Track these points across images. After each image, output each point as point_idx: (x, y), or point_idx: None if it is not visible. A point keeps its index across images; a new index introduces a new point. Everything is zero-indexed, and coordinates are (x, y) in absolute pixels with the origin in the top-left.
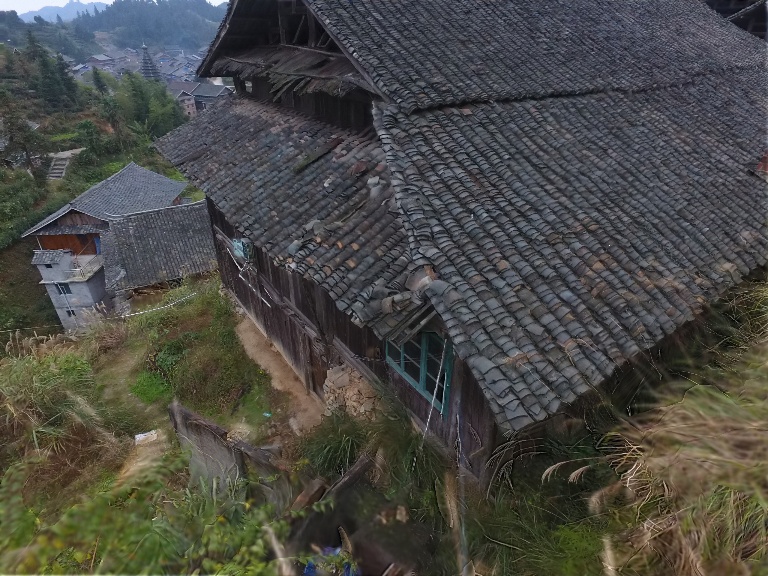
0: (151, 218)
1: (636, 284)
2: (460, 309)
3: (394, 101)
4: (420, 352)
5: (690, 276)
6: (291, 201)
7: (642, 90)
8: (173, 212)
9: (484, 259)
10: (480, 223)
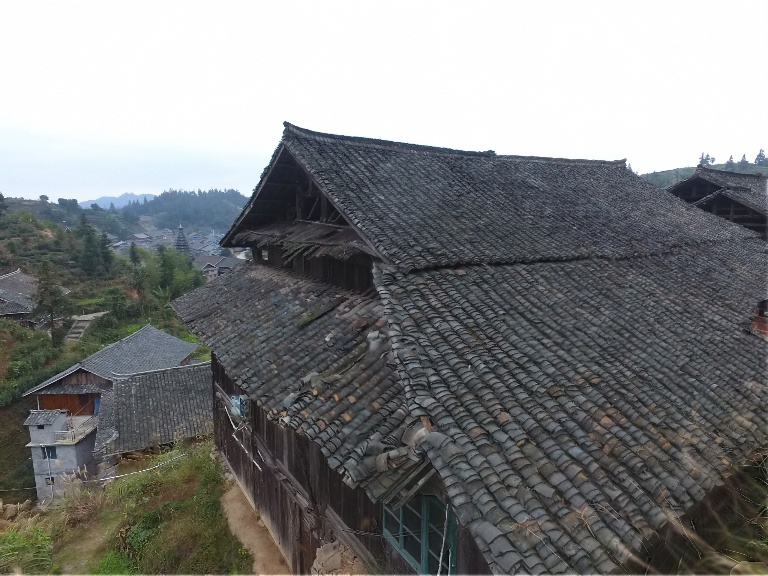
0: (156, 378)
1: (651, 442)
2: (459, 464)
3: (393, 262)
4: (420, 522)
5: (708, 435)
6: (292, 355)
7: (625, 258)
8: (179, 372)
9: (483, 410)
10: (478, 374)
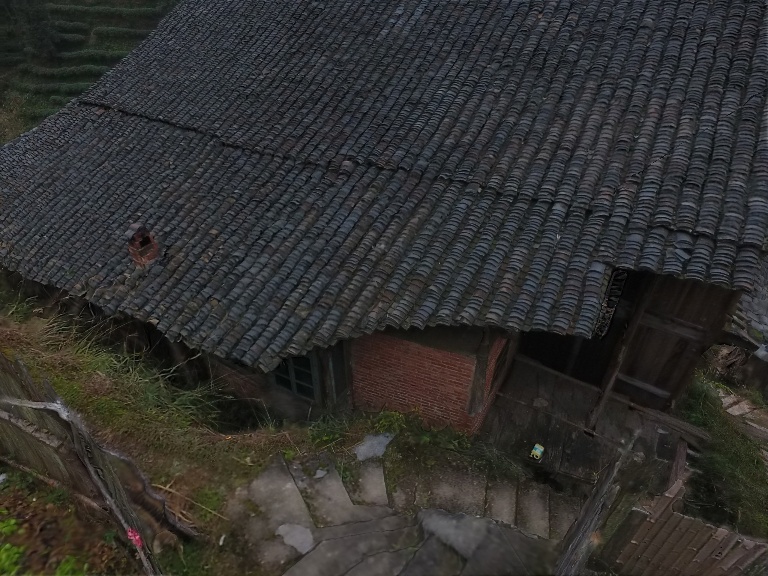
0: None
1: None
2: None
3: None
4: None
5: None
6: None
7: (239, 147)
8: None
9: None
10: None
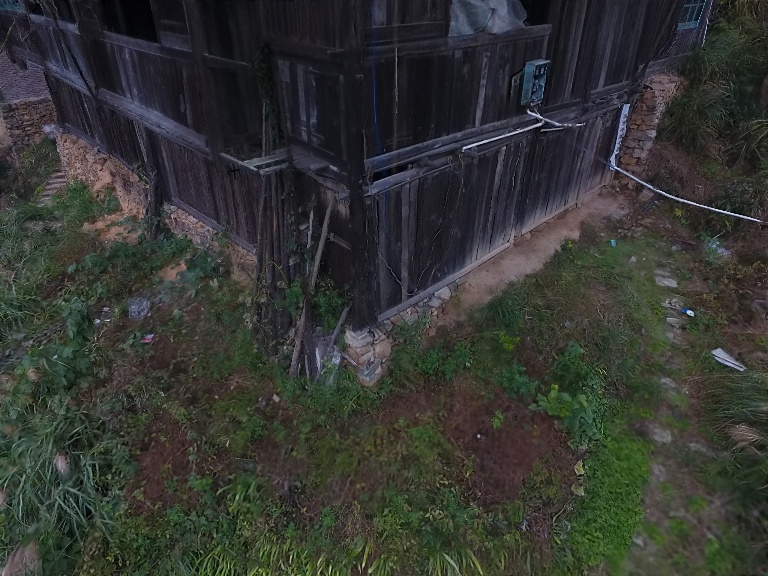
0: None
1: None
2: None
3: None
4: None
5: None
6: None
7: None
8: None
9: None
10: None
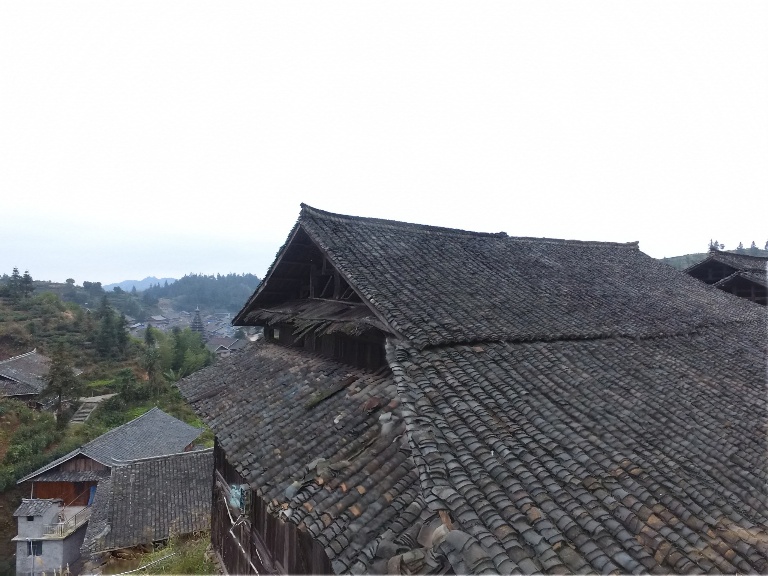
0: (157, 465)
1: (710, 548)
2: (486, 572)
3: (407, 338)
4: None
5: None
6: (298, 438)
7: (650, 337)
8: (181, 459)
9: (511, 505)
10: (502, 461)
